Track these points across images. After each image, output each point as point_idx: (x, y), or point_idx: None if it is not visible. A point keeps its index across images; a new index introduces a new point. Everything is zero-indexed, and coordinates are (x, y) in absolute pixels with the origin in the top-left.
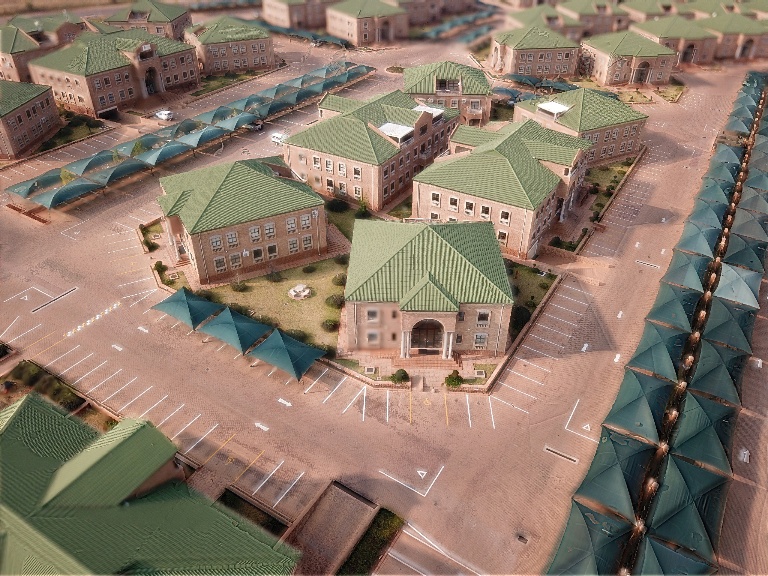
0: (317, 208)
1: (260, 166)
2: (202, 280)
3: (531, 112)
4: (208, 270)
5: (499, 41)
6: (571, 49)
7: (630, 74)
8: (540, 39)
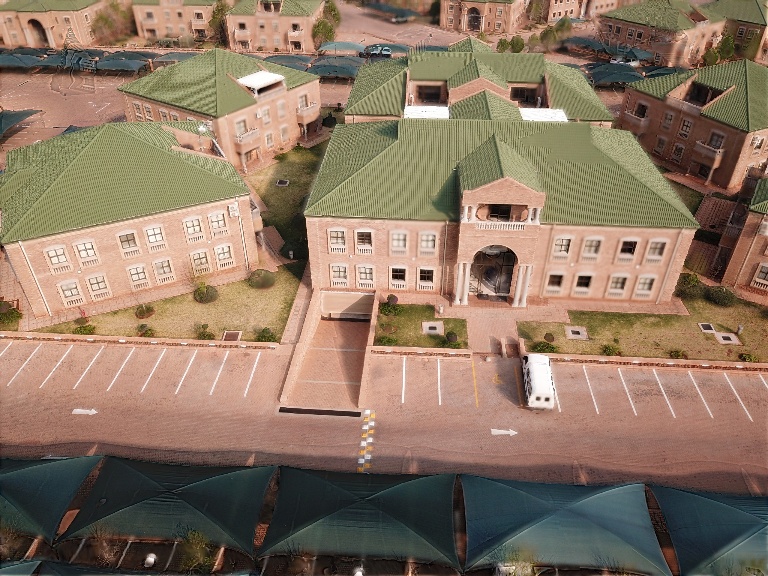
0: None
1: None
2: None
3: (252, 105)
4: None
5: None
6: None
7: None
8: None
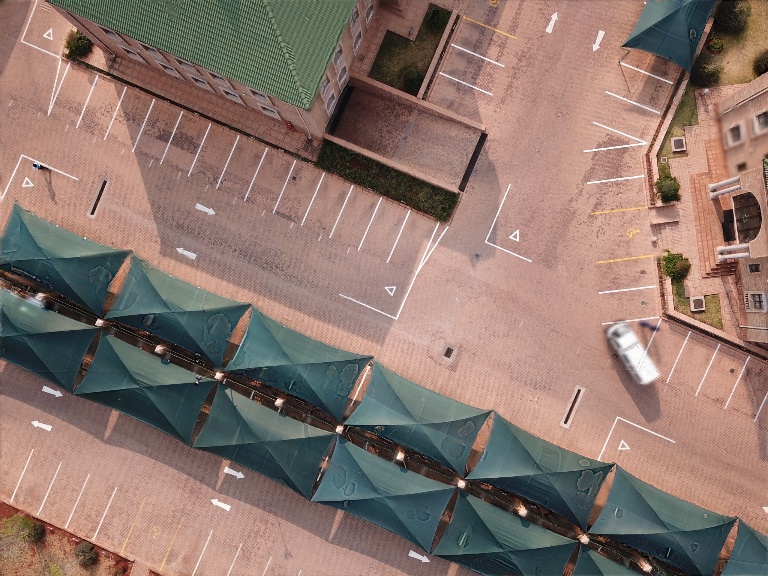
0: None
1: None
2: None
3: None
4: None
5: None
6: None
7: None
8: None
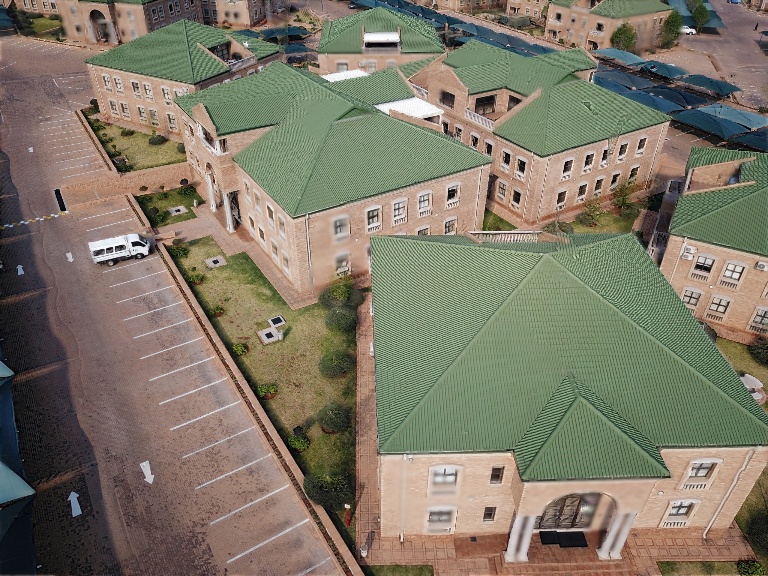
0: None
1: (515, 245)
2: None
3: (355, 53)
4: None
5: None
6: None
7: (263, 8)
8: None
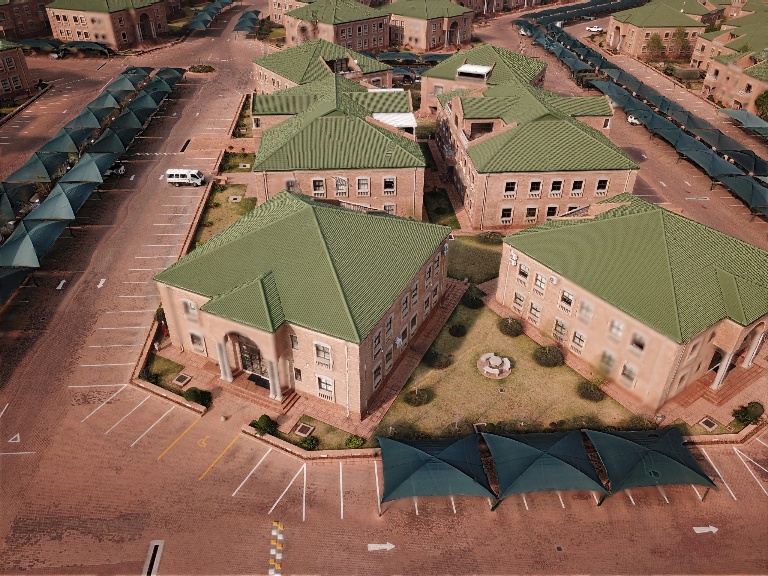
0: None
1: (326, 205)
2: (362, 413)
3: (449, 79)
4: (366, 393)
5: None
6: (383, 18)
7: (443, 37)
8: (351, 11)
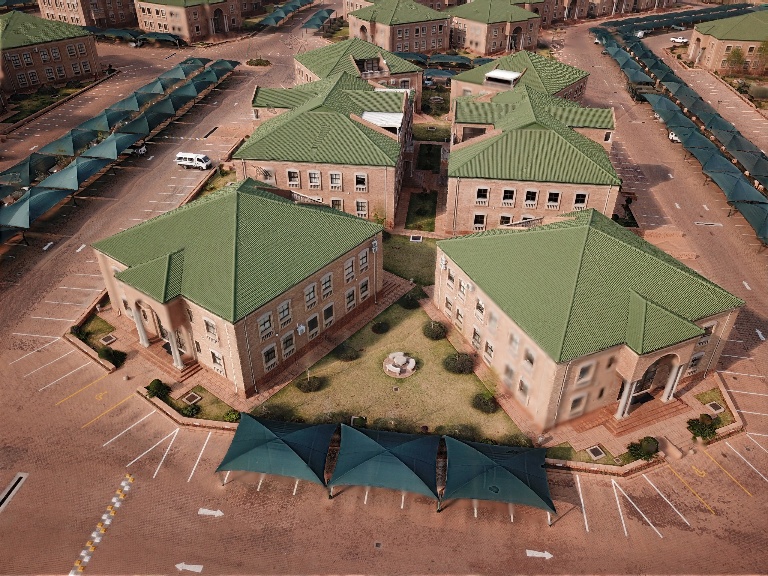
0: (375, 237)
1: (263, 193)
2: (248, 391)
3: (477, 84)
4: (254, 372)
5: (367, 18)
6: (444, 21)
7: (505, 41)
8: (411, 12)
